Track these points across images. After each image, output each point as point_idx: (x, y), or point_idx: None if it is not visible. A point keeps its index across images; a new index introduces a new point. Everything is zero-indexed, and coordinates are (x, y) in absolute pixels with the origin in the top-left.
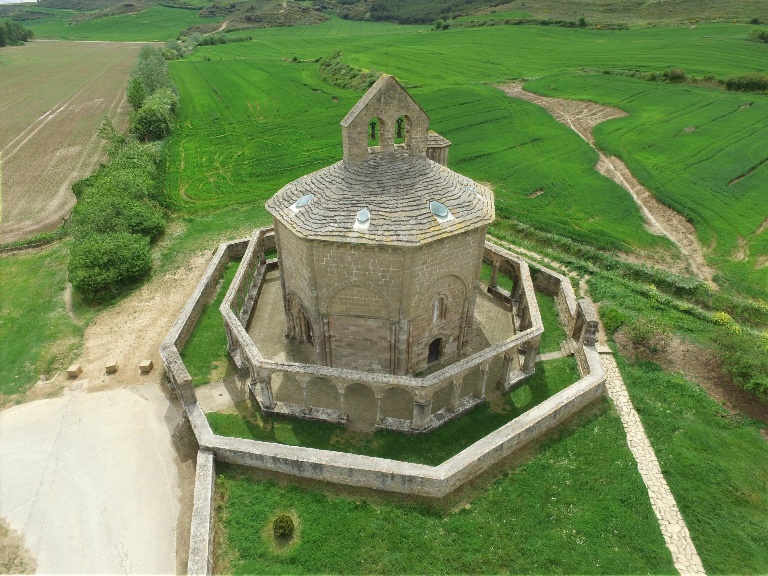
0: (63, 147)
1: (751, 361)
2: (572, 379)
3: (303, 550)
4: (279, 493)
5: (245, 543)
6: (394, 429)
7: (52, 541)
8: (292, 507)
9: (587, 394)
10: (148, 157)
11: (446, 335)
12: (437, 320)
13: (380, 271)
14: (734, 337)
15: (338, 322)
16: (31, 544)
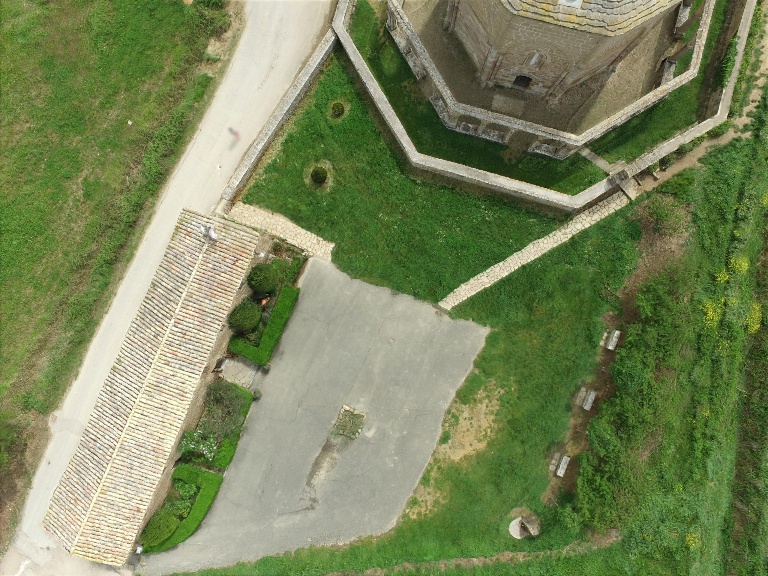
0: None
1: (662, 291)
2: (578, 187)
3: (337, 127)
4: (351, 90)
5: (320, 100)
6: (436, 110)
7: (255, 18)
8: (350, 103)
9: (553, 202)
10: None
11: (536, 79)
12: (534, 64)
13: (494, 1)
14: (684, 275)
15: (465, 4)
16: (247, 11)
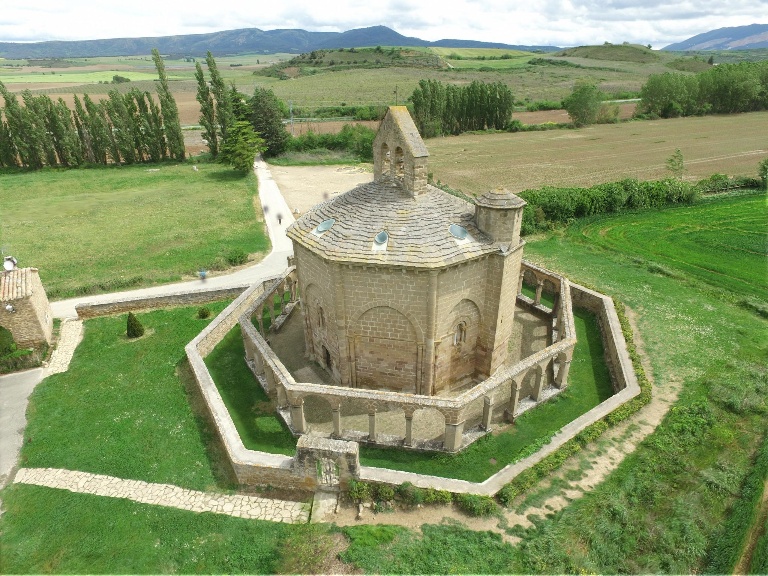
0: (688, 174)
1: None
2: None
3: None
4: None
5: (204, 307)
6: None
7: None
8: None
9: None
10: (660, 192)
11: (330, 352)
12: None
13: None
14: None
15: None
16: None
